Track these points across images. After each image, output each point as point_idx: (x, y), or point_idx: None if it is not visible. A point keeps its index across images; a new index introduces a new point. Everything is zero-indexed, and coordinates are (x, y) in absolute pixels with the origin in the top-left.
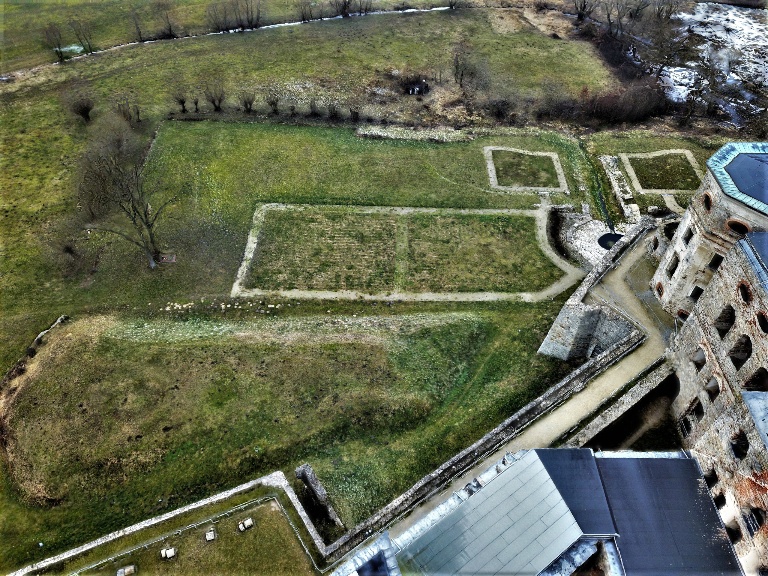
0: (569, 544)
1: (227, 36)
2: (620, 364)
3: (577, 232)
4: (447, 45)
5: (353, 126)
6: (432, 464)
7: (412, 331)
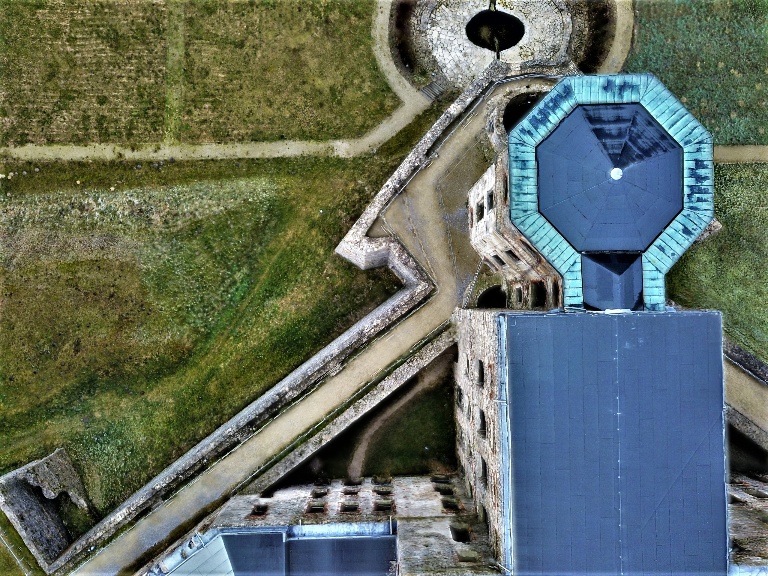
0: None
1: None
2: (393, 333)
3: (439, 10)
4: None
5: None
6: (190, 418)
7: (178, 226)
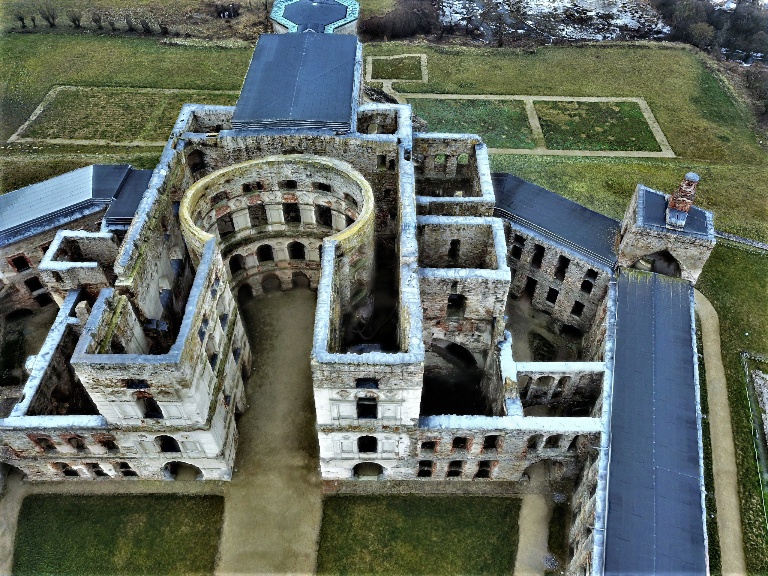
0: (79, 201)
1: None
2: None
3: None
4: None
5: (160, 38)
6: None
7: (129, 158)
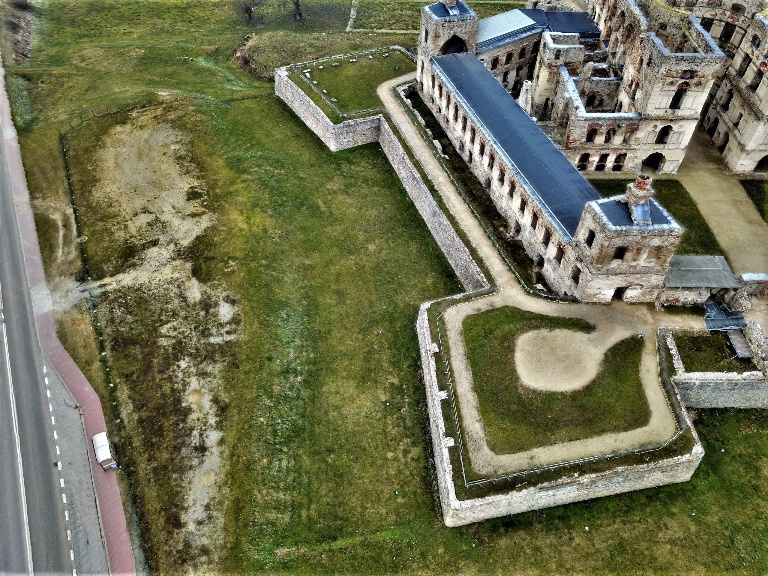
0: (530, 24)
1: None
2: None
3: None
4: None
5: None
6: None
7: None
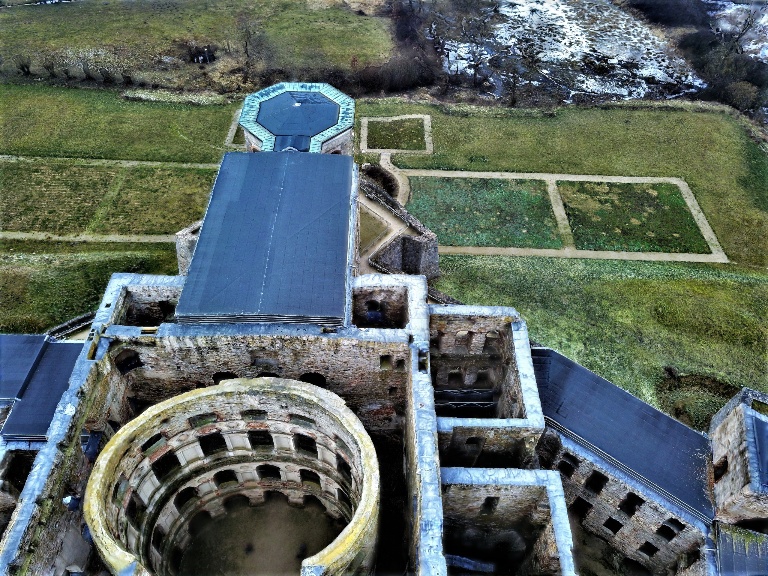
0: None
1: (40, 6)
2: None
3: None
4: (254, 19)
5: (122, 89)
6: None
7: (70, 265)
